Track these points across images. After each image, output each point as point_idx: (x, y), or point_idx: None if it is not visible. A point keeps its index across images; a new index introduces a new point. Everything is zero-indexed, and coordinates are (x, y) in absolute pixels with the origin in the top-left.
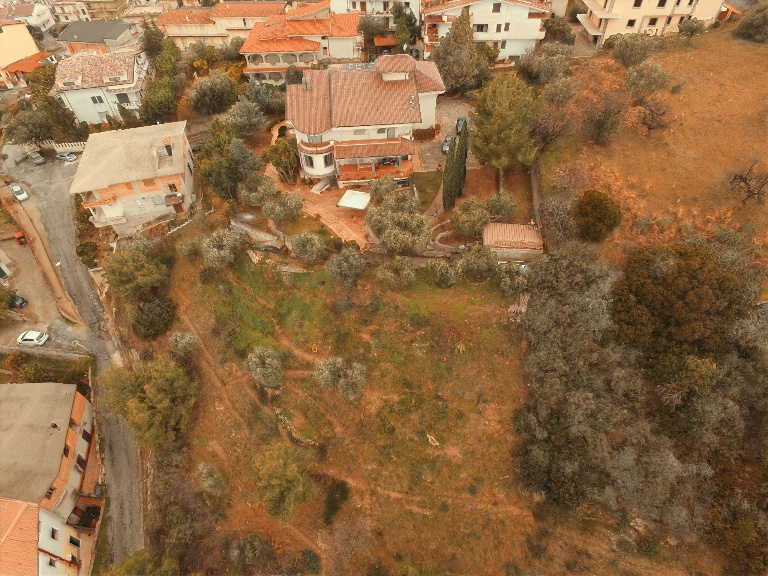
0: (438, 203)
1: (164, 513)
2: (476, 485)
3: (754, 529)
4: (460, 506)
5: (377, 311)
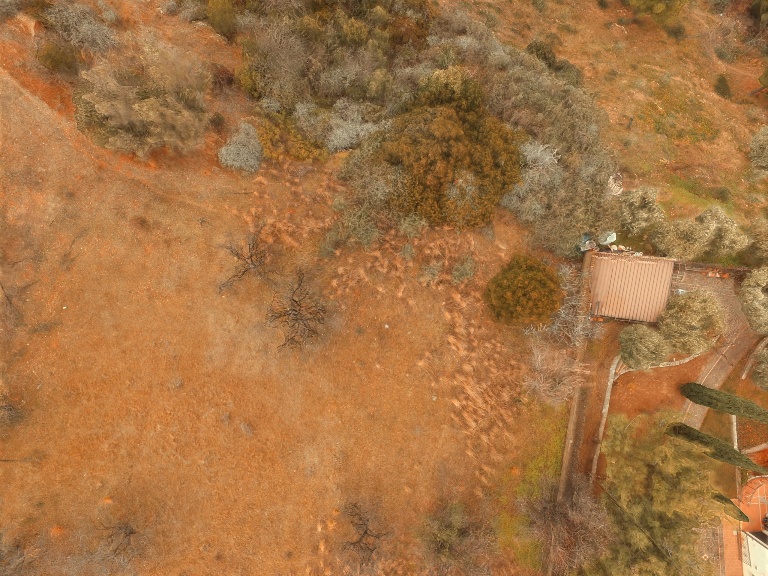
0: (699, 409)
1: None
2: (611, 76)
3: (407, 0)
4: (621, 66)
5: (766, 217)
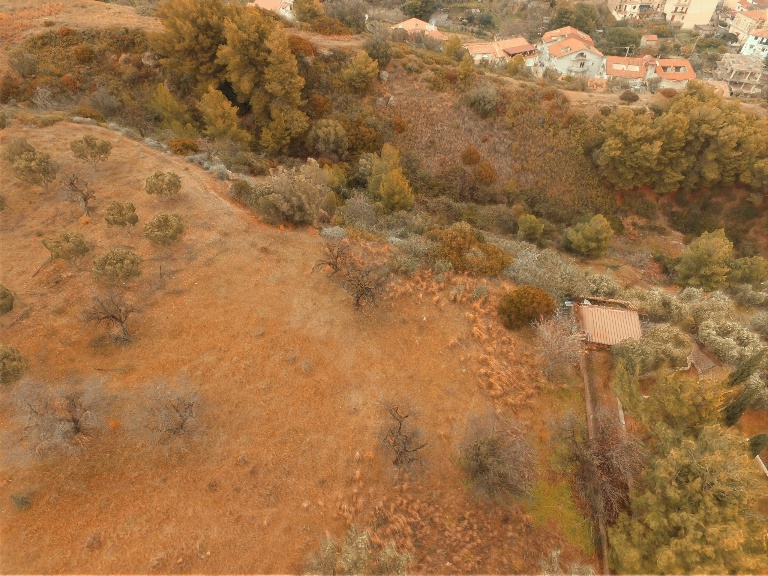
0: None
1: (765, 300)
2: None
3: None
4: None
5: None
